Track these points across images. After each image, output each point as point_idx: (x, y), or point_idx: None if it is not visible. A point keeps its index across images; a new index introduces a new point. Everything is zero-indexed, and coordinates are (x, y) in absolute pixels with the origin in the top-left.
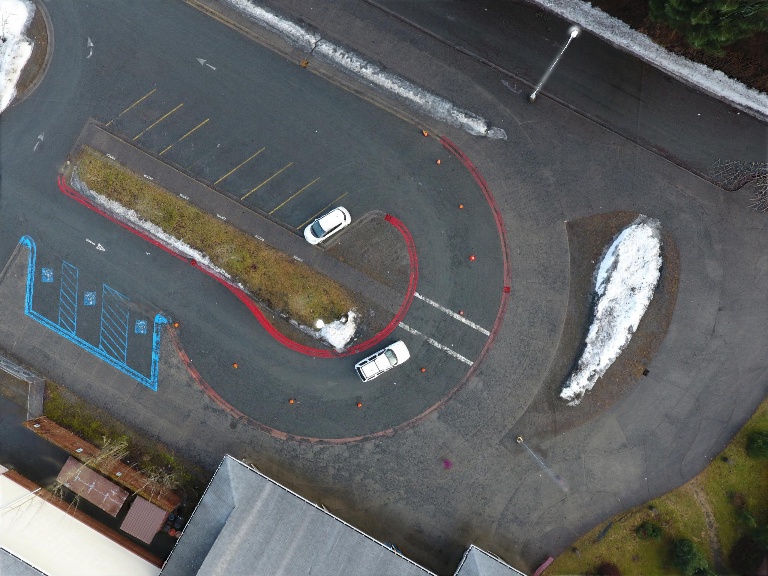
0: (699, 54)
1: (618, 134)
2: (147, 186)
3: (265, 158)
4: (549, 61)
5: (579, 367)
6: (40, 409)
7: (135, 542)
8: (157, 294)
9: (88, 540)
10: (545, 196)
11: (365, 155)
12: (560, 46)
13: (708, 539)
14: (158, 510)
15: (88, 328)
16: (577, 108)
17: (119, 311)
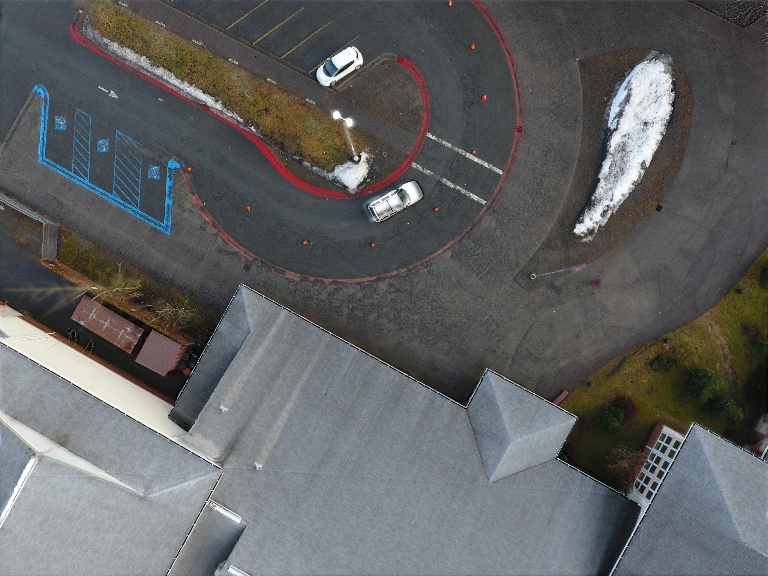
0: None
1: None
2: (159, 32)
3: (277, 3)
4: None
5: (592, 202)
6: (54, 255)
7: (150, 384)
8: (170, 140)
9: (103, 374)
10: (557, 35)
11: None
12: None
13: (723, 371)
14: (173, 343)
15: (101, 174)
16: None
17: (132, 157)
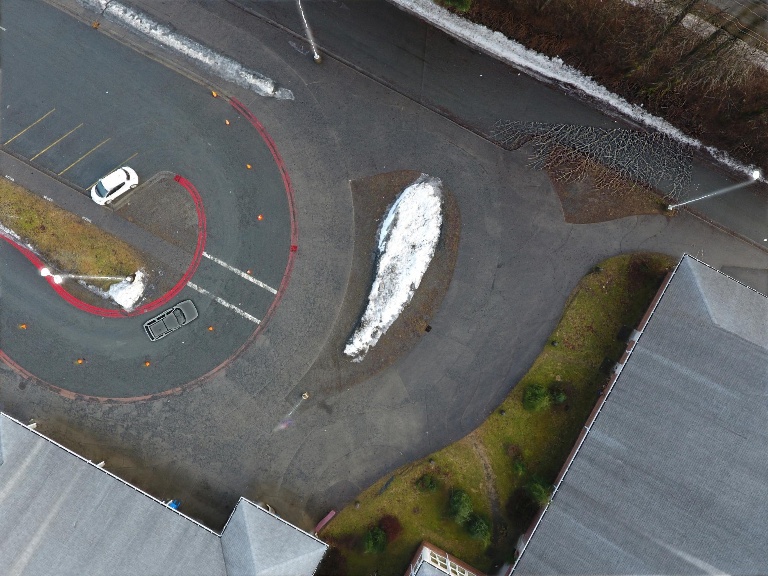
0: (478, 15)
1: (402, 95)
2: None
3: (55, 119)
4: (336, 23)
5: (361, 324)
6: None
7: None
8: None
9: None
10: (331, 156)
11: (155, 116)
12: (347, 8)
13: (486, 490)
14: None
15: None
16: (363, 69)
17: None
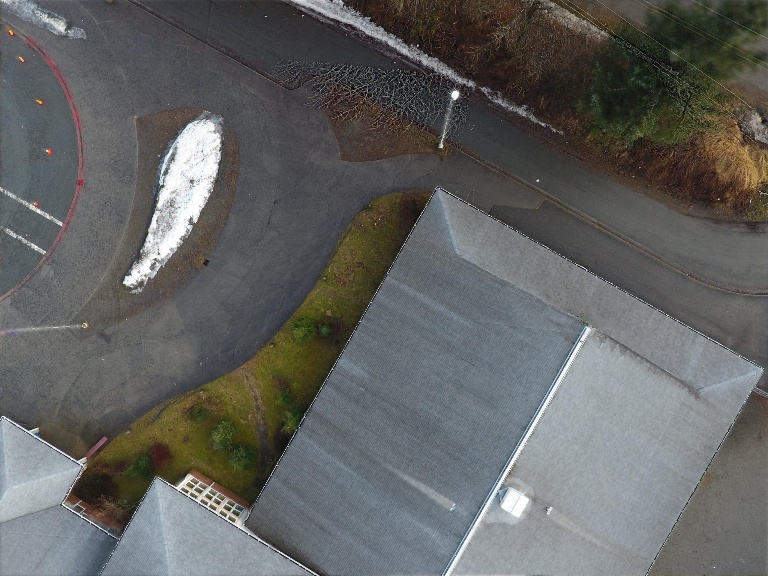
0: None
1: (189, 34)
2: None
3: None
4: None
5: (139, 255)
6: None
7: None
8: None
9: None
10: (118, 93)
11: None
12: None
13: (254, 421)
14: None
15: None
16: (153, 9)
17: None
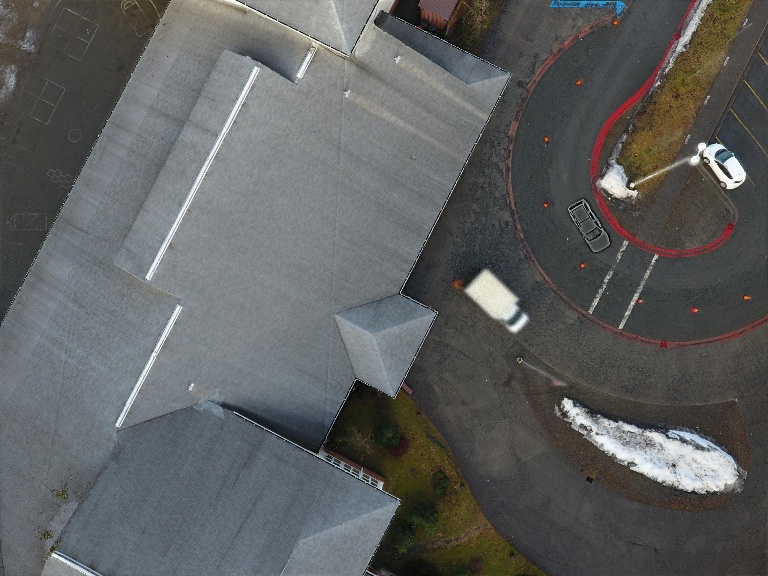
0: None
1: None
2: None
3: None
4: None
5: (595, 415)
6: None
7: None
8: (645, 2)
9: None
10: (761, 380)
11: None
12: None
13: (436, 539)
14: (449, 13)
15: None
16: None
17: None
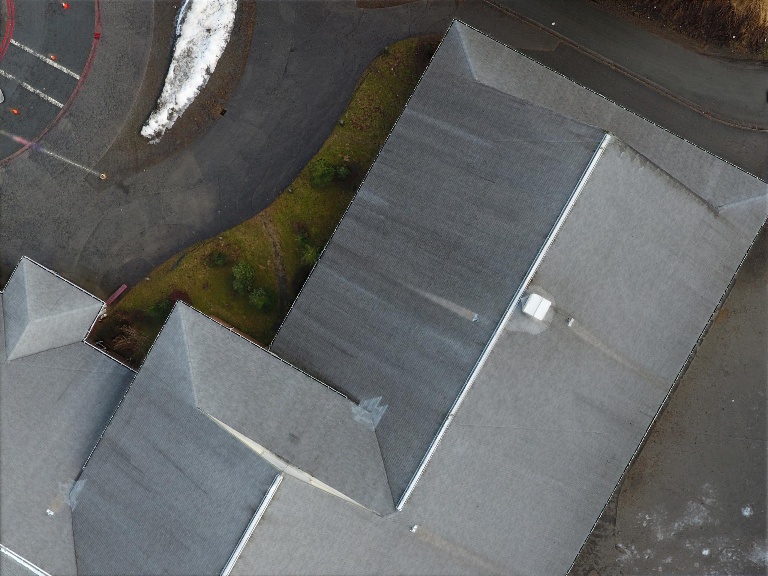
0: None
1: None
2: None
3: None
4: None
5: (157, 105)
6: None
7: None
8: None
9: None
10: None
11: None
12: None
13: (273, 267)
14: None
15: None
16: None
17: None
